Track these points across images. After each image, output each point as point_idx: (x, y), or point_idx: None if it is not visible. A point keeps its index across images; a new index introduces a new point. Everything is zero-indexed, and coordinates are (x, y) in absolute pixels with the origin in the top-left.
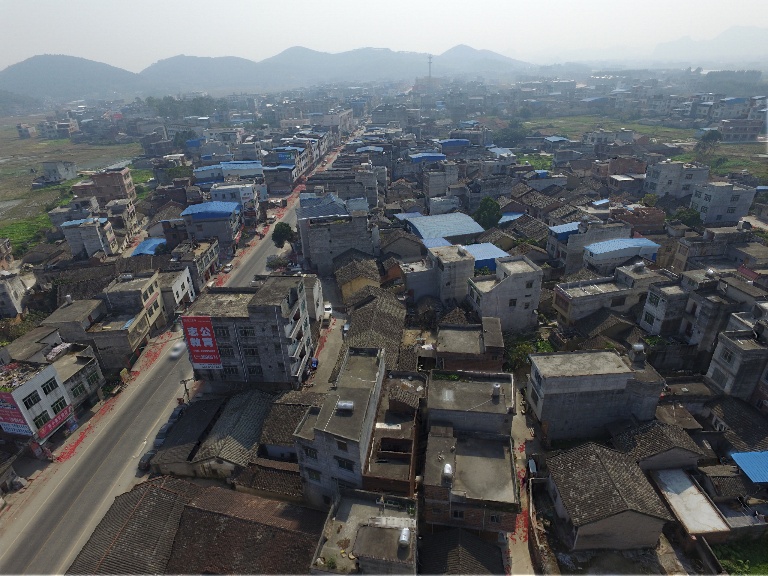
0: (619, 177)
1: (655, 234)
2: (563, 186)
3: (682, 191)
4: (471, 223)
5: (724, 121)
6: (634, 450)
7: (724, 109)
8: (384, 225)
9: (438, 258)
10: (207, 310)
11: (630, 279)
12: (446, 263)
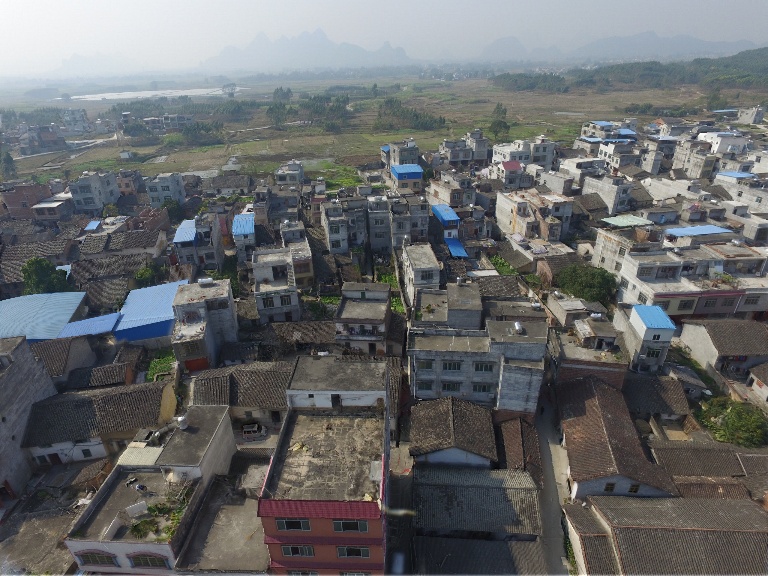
0: (45, 205)
1: None
2: (1, 235)
3: (111, 197)
4: (53, 296)
5: None
6: (461, 275)
7: None
8: None
9: (207, 301)
10: (343, 481)
11: (297, 232)
12: None
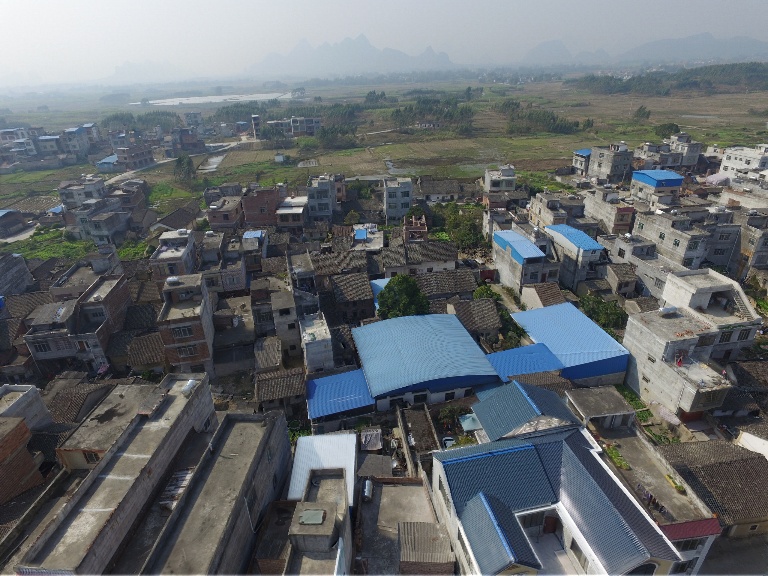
0: (288, 211)
1: (500, 226)
2: (268, 243)
3: (335, 203)
4: (430, 319)
5: (124, 149)
6: None
7: (78, 140)
8: (356, 444)
9: (699, 336)
10: None
11: (646, 248)
12: (716, 330)
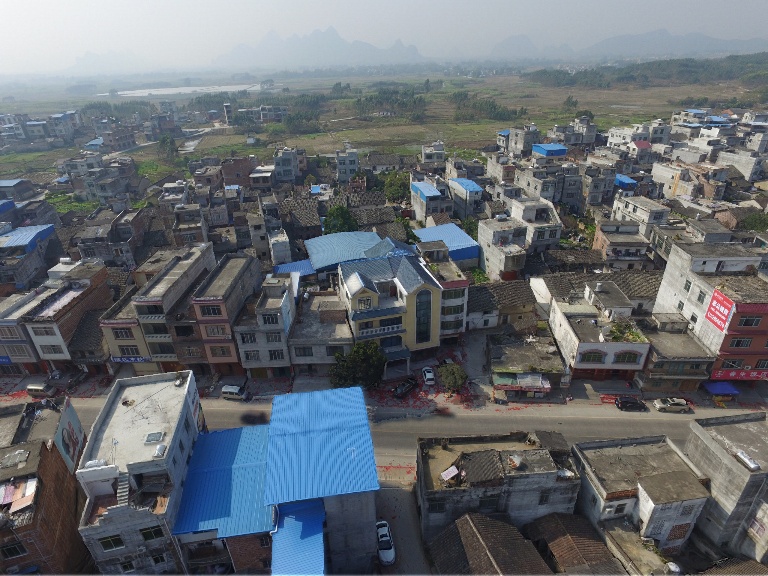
0: (259, 175)
1: None
2: None
3: None
4: (358, 233)
5: (109, 132)
6: None
7: (64, 125)
8: None
9: (515, 229)
10: None
11: None
12: None
